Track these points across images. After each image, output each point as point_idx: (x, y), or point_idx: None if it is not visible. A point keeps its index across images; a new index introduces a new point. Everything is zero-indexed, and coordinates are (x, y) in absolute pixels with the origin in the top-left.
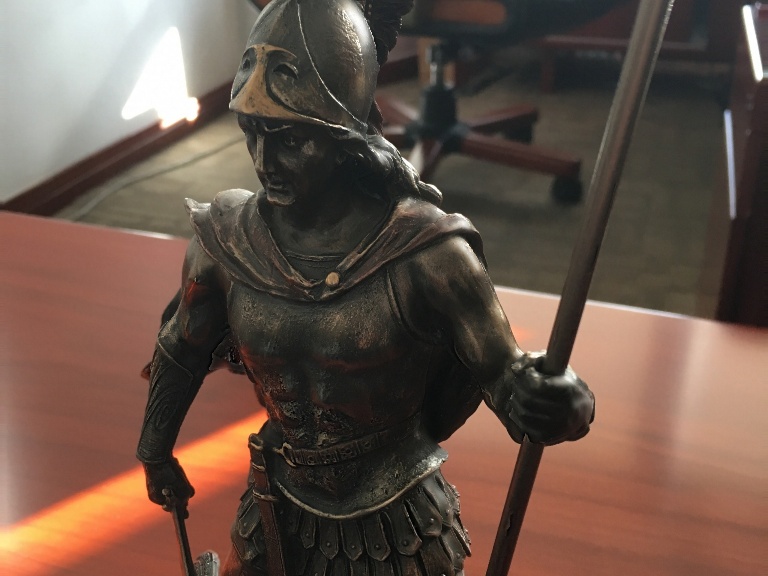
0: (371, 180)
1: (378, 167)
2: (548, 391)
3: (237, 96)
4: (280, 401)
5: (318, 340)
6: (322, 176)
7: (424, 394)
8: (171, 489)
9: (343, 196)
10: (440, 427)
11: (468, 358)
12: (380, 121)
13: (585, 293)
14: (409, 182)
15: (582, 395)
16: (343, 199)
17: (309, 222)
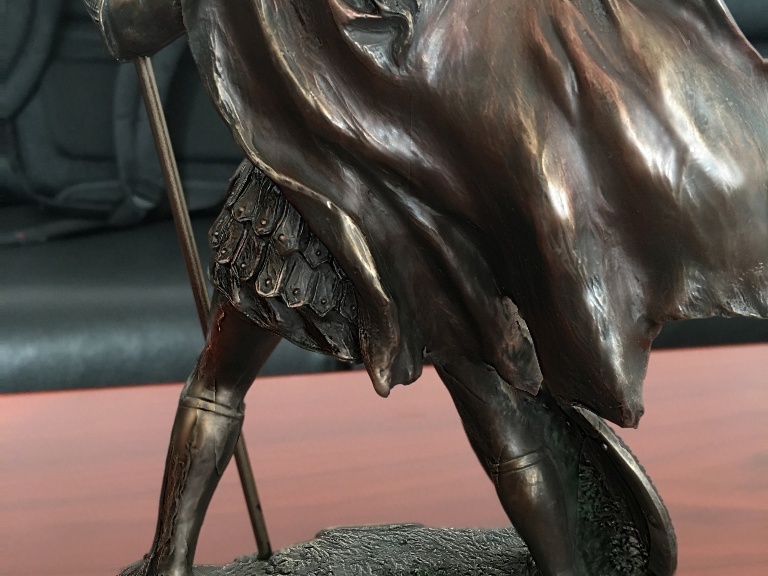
0: None
1: None
2: None
3: None
4: None
5: None
6: None
7: None
8: None
9: None
10: None
11: None
12: None
13: None
14: None
15: None
16: None
17: None
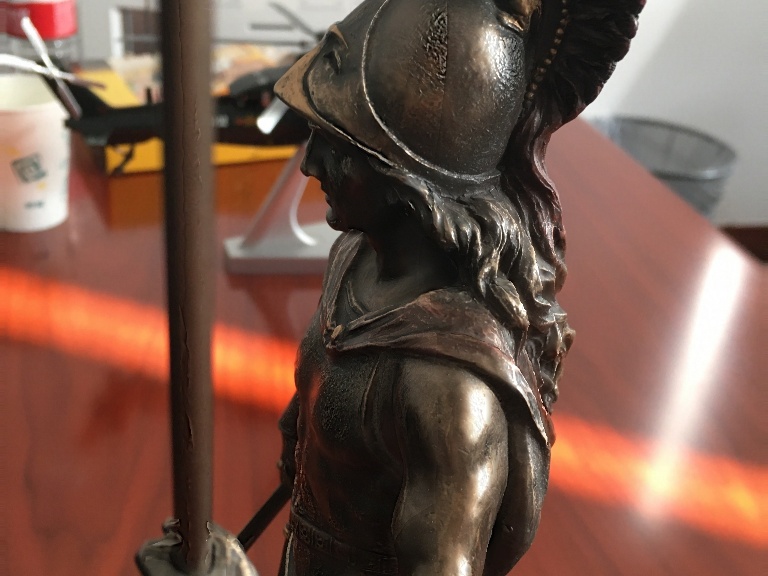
0: None
1: (432, 231)
2: None
3: None
4: None
5: None
6: (366, 208)
7: None
8: (286, 464)
9: (409, 250)
10: None
11: None
12: (547, 192)
13: (188, 477)
14: (478, 274)
15: None
16: (408, 253)
17: None
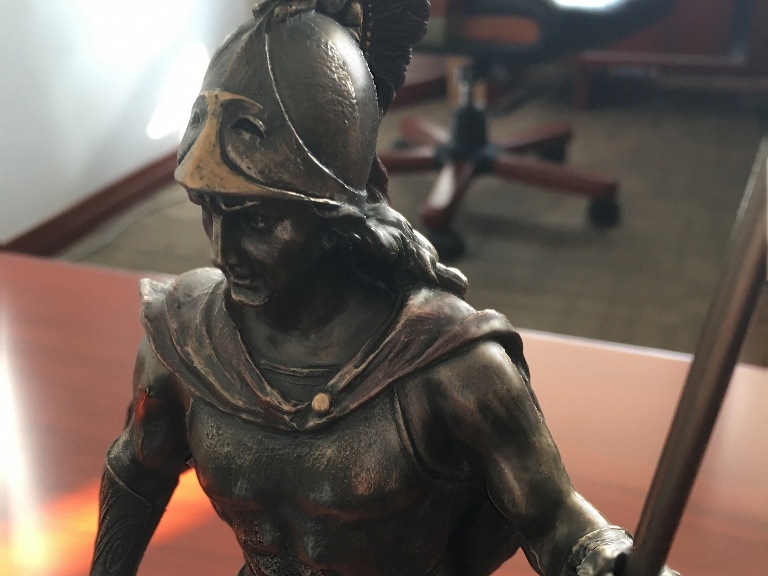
0: (372, 266)
1: (381, 250)
2: None
3: (182, 162)
4: (256, 554)
5: (303, 481)
6: (304, 265)
7: (447, 541)
8: None
9: (335, 288)
10: (468, 573)
11: (506, 507)
12: (385, 183)
13: (695, 473)
14: (423, 267)
15: None
16: (335, 292)
17: (290, 322)
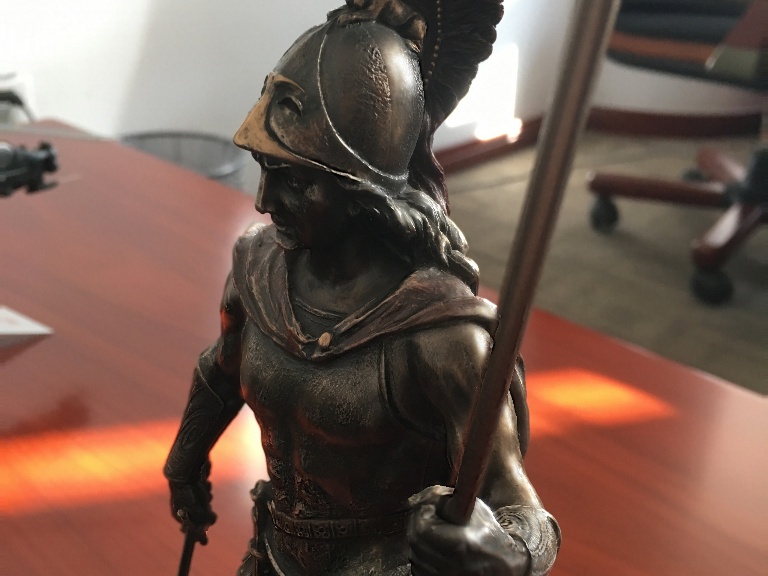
0: (394, 240)
1: (397, 227)
2: (433, 540)
3: None
4: (269, 455)
5: (304, 402)
6: (330, 225)
7: None
8: (187, 512)
9: (362, 251)
10: None
11: (453, 466)
12: (440, 176)
13: (490, 434)
14: (438, 250)
15: (490, 556)
16: (361, 255)
17: (325, 272)
